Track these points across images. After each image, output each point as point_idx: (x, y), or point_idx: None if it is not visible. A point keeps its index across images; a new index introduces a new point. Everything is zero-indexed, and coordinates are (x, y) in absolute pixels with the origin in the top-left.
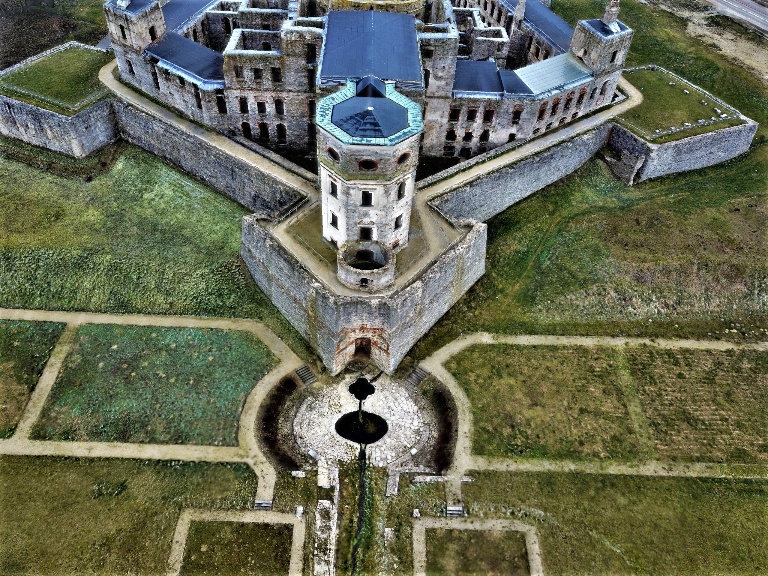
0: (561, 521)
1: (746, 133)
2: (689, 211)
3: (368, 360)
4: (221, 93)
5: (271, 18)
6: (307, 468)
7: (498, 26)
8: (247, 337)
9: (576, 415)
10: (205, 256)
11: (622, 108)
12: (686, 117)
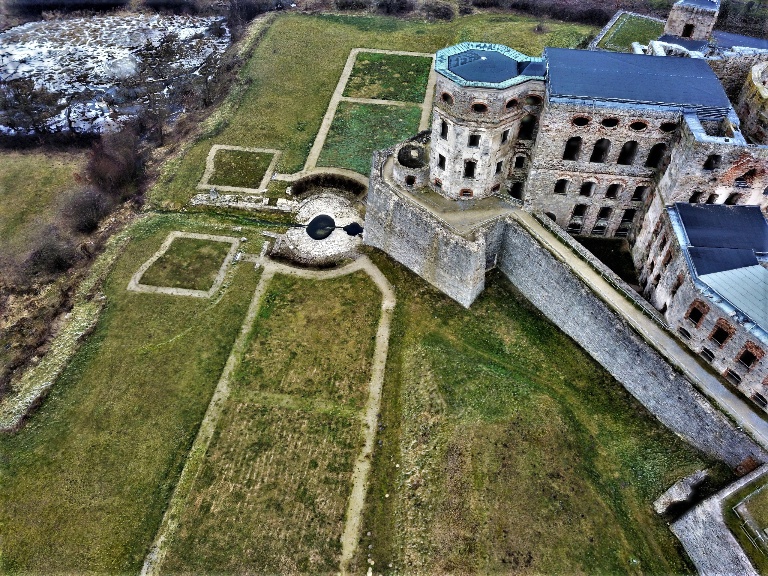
0: (206, 313)
1: None
2: (594, 572)
3: None
4: None
5: None
6: (295, 198)
7: None
8: None
9: (290, 347)
10: None
11: None
12: None
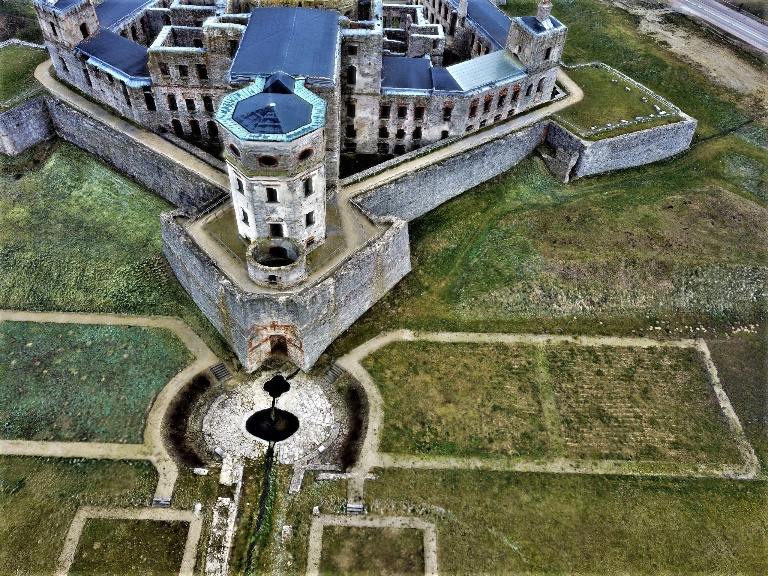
0: (461, 518)
1: (685, 130)
2: (622, 208)
3: (286, 357)
4: (149, 90)
5: (203, 15)
6: (212, 466)
7: (445, 23)
8: (165, 334)
9: (488, 412)
10: (127, 253)
11: (561, 105)
12: (624, 114)
